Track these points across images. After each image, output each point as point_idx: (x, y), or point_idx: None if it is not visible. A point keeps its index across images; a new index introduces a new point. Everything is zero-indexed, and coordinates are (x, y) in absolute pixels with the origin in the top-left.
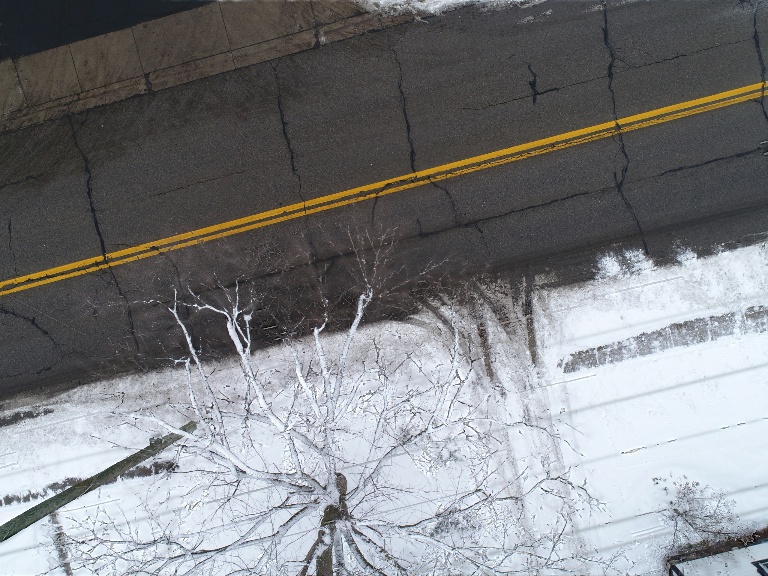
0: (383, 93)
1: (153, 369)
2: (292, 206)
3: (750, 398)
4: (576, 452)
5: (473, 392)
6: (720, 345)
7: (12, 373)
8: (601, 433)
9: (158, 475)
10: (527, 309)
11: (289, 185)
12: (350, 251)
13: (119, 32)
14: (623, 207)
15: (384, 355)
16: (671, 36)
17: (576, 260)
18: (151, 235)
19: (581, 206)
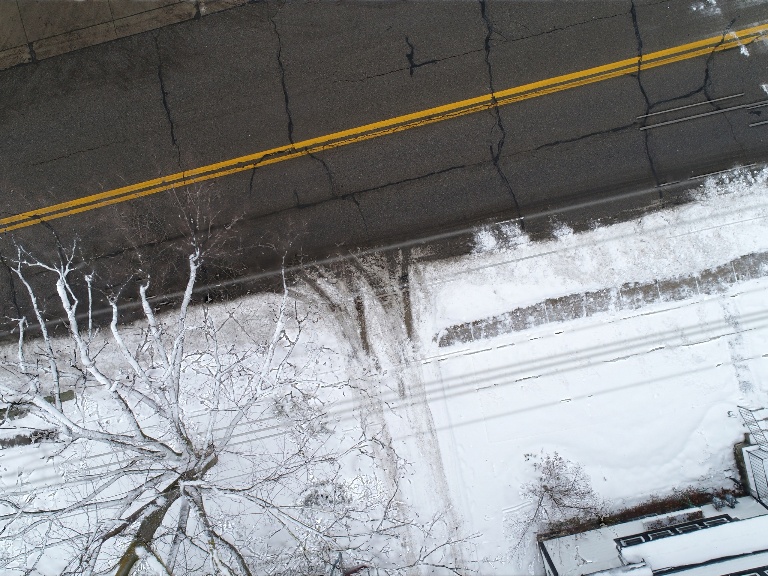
0: (262, 64)
1: (34, 338)
2: (171, 176)
3: (622, 375)
4: None
5: (349, 365)
6: (594, 321)
7: None
8: (473, 408)
9: (37, 444)
10: (404, 283)
11: (169, 155)
12: (228, 222)
13: (3, 1)
14: (499, 181)
15: (259, 326)
16: (548, 9)
17: (452, 234)
18: None
19: (457, 179)
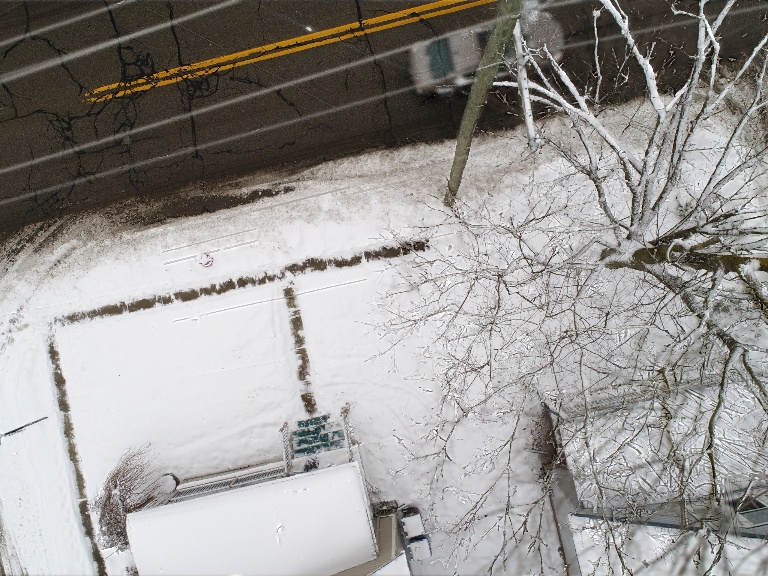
0: None
1: (405, 144)
2: None
3: None
4: None
5: (752, 170)
6: None
7: (252, 148)
8: None
9: (408, 255)
10: None
11: None
12: None
13: None
14: None
15: None
16: None
17: None
18: (412, 1)
19: None
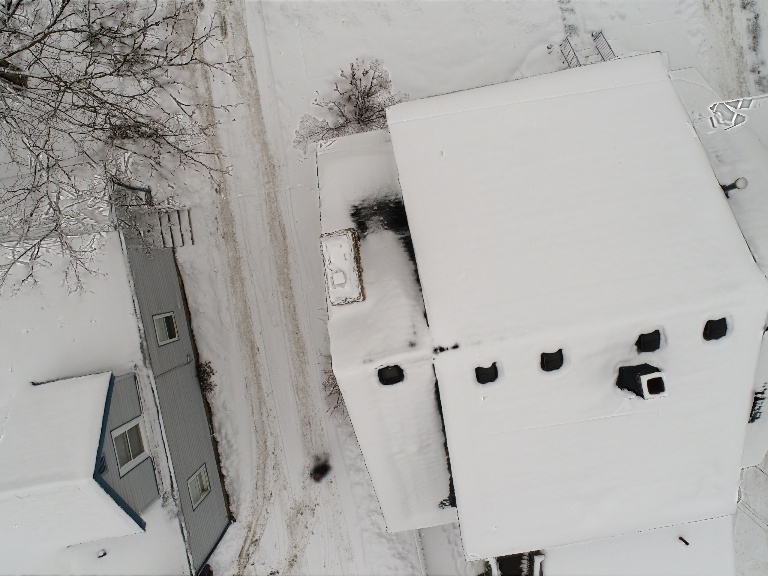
0: None
1: None
2: None
3: (445, 11)
4: None
5: (171, 2)
6: None
7: None
8: (293, 43)
9: None
10: None
11: None
12: None
13: None
14: None
15: None
16: None
17: None
18: None
19: None
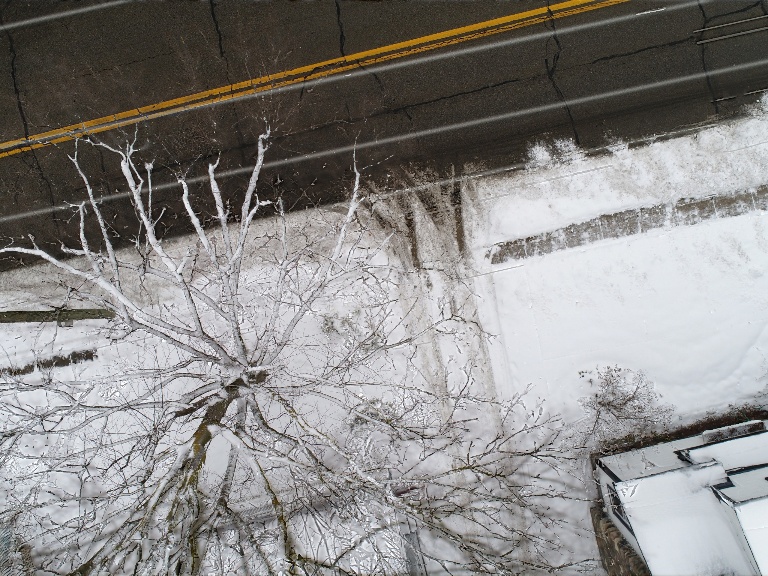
0: None
1: (74, 256)
2: (219, 89)
3: (679, 290)
4: (473, 293)
5: None
6: (649, 236)
7: None
8: (527, 324)
9: None
10: (456, 199)
11: (216, 68)
12: None
13: None
14: (554, 95)
15: None
16: None
17: (506, 149)
18: None
19: (512, 93)
